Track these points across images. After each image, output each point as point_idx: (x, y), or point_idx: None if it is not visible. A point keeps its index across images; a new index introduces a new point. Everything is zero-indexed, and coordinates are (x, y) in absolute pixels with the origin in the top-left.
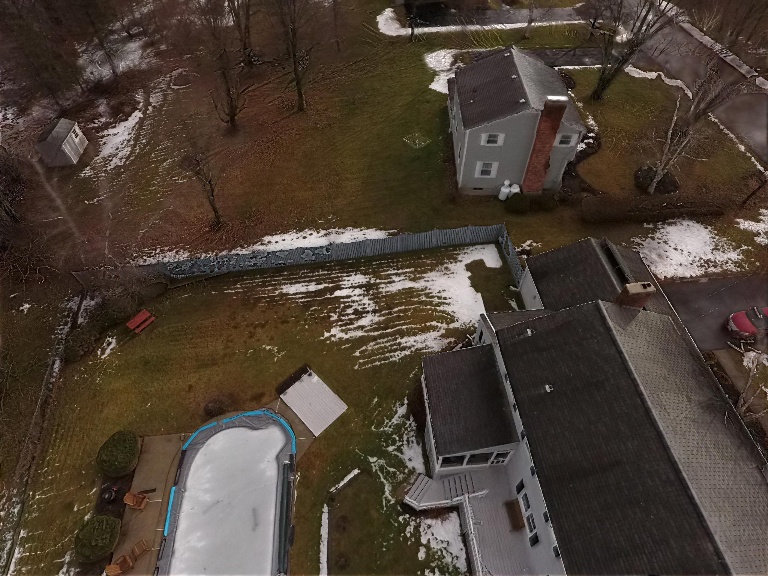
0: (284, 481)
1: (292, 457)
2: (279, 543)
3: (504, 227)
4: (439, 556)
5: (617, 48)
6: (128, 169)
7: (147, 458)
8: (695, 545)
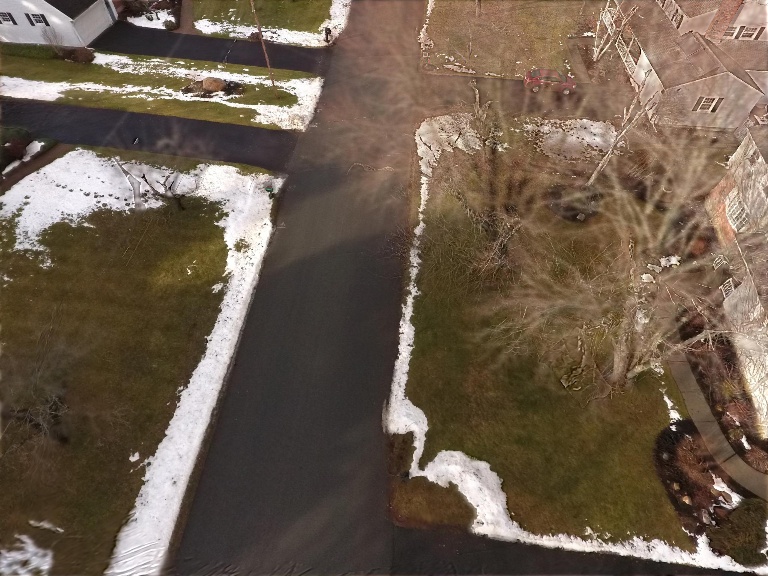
0: None
1: None
2: None
3: None
4: None
5: None
6: None
7: None
8: None
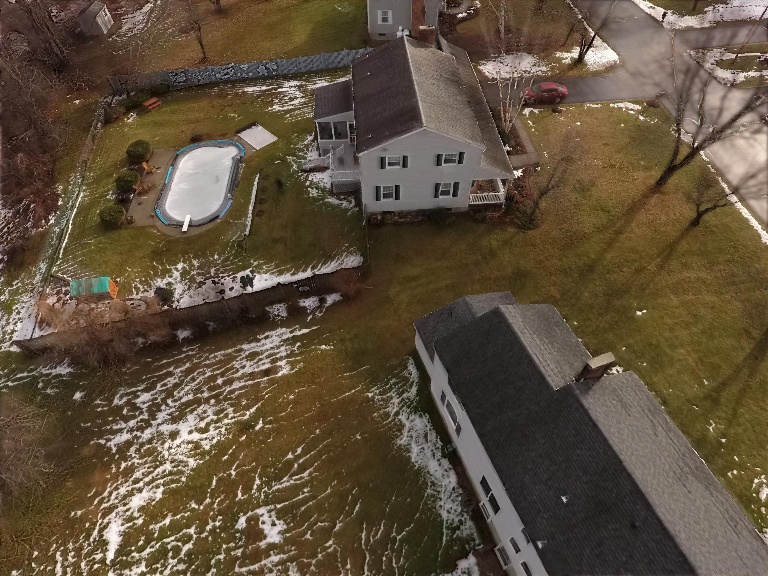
0: None
1: (242, 157)
2: None
3: None
4: (317, 183)
5: None
6: (143, 34)
7: (156, 156)
8: (409, 101)
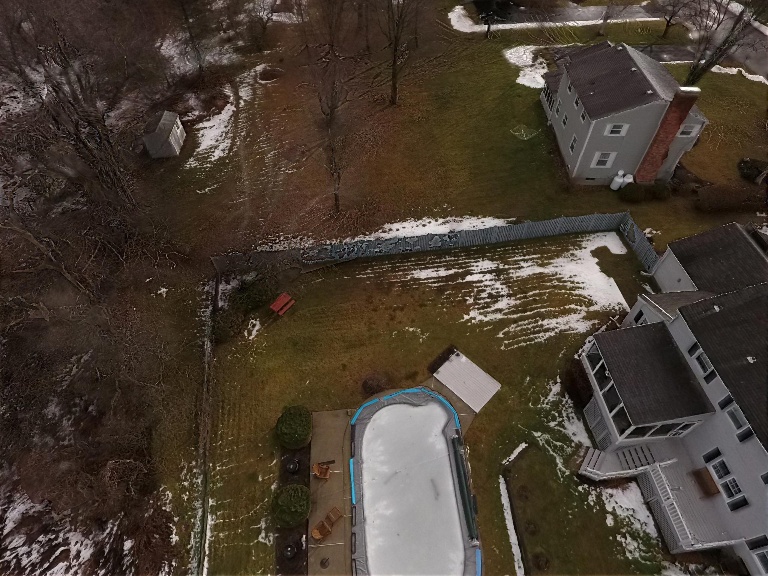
0: (457, 454)
1: (458, 432)
2: (464, 511)
3: (629, 215)
4: (627, 522)
5: (692, 45)
6: (233, 160)
7: (319, 432)
8: None
